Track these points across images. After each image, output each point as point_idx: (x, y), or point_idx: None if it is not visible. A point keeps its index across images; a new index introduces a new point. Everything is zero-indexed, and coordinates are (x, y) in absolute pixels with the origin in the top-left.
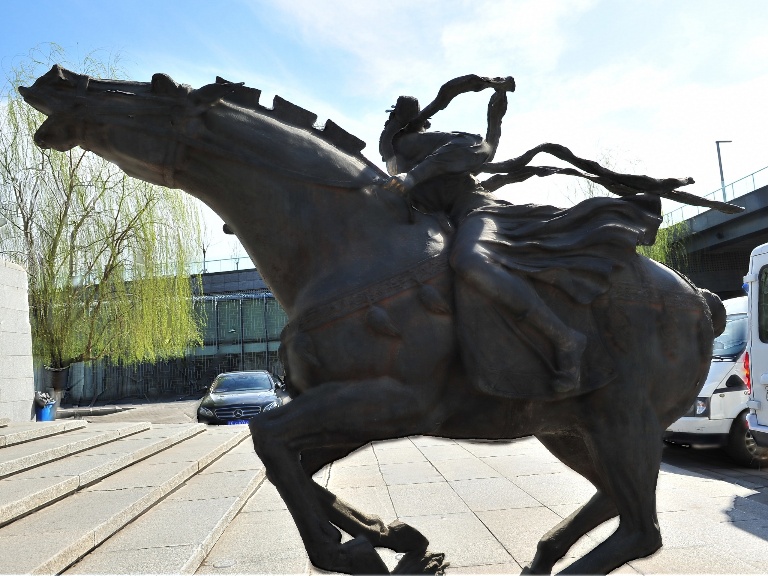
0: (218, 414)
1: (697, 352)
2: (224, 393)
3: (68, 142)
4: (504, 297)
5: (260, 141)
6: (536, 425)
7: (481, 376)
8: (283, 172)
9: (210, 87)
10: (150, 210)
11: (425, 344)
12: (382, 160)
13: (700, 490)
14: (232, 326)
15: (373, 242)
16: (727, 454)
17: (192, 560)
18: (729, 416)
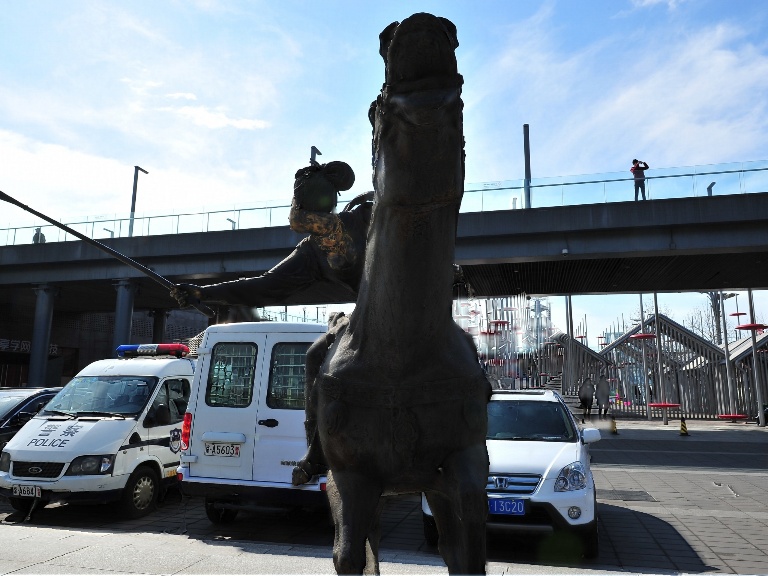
0: None
1: None
2: None
3: None
4: None
5: None
6: None
7: None
8: None
9: None
10: None
11: None
12: (300, 207)
13: (166, 541)
14: None
15: None
16: (98, 510)
17: None
18: (127, 471)
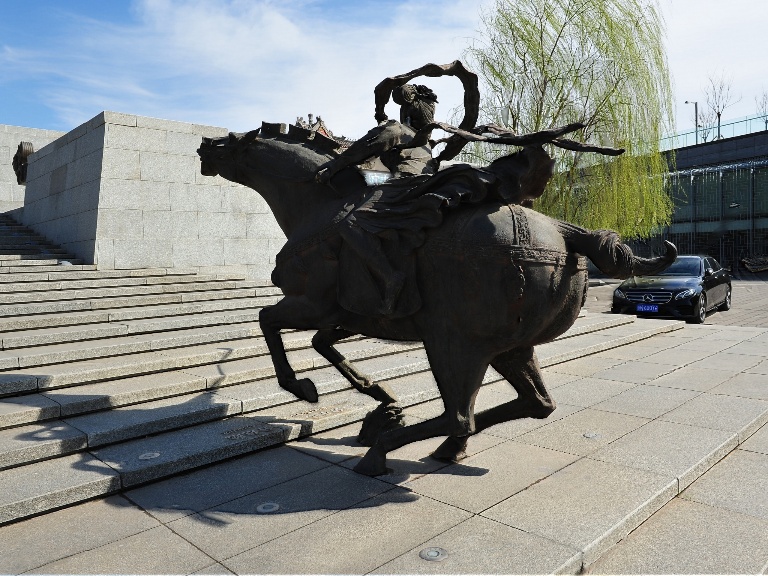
0: (629, 297)
1: (500, 294)
2: (650, 277)
3: (212, 173)
4: (356, 250)
5: (268, 160)
6: (394, 334)
7: (346, 299)
8: (274, 177)
9: (248, 134)
10: (621, 90)
11: (319, 278)
12: None
13: None
14: (735, 200)
15: (312, 214)
16: None
17: (332, 383)
18: None
